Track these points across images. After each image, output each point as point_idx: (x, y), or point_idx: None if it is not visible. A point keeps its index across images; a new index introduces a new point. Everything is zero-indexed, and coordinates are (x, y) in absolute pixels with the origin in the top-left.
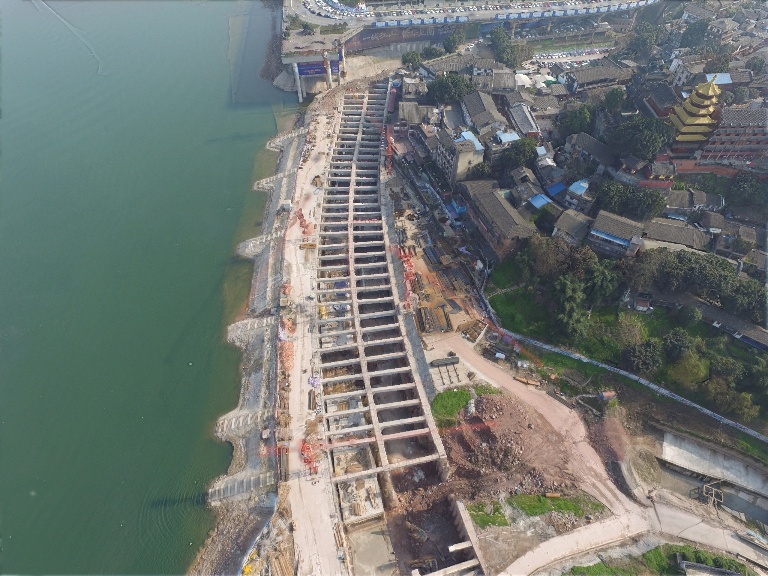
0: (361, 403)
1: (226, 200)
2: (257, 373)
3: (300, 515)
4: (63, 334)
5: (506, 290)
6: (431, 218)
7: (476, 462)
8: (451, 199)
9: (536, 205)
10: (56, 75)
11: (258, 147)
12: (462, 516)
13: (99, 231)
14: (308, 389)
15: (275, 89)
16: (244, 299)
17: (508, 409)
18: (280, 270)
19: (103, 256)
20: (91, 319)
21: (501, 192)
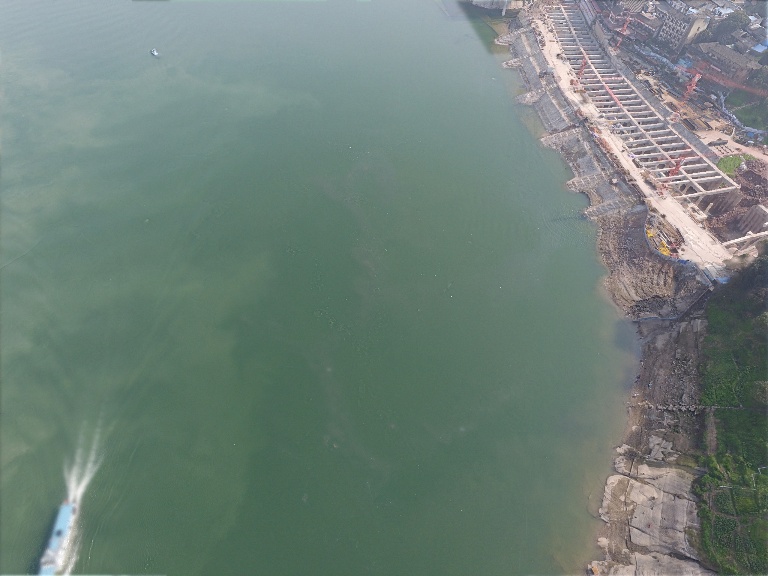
0: (661, 172)
1: (488, 73)
2: (584, 157)
3: (664, 211)
4: (426, 144)
5: (742, 107)
6: (663, 73)
7: (754, 195)
8: (678, 59)
9: (759, 51)
10: (286, 0)
11: (489, 43)
12: (766, 211)
13: (405, 91)
14: (631, 159)
15: (476, 7)
16: (541, 126)
17: (767, 167)
18: (568, 104)
19: (421, 104)
20: (440, 136)
21: (728, 45)
